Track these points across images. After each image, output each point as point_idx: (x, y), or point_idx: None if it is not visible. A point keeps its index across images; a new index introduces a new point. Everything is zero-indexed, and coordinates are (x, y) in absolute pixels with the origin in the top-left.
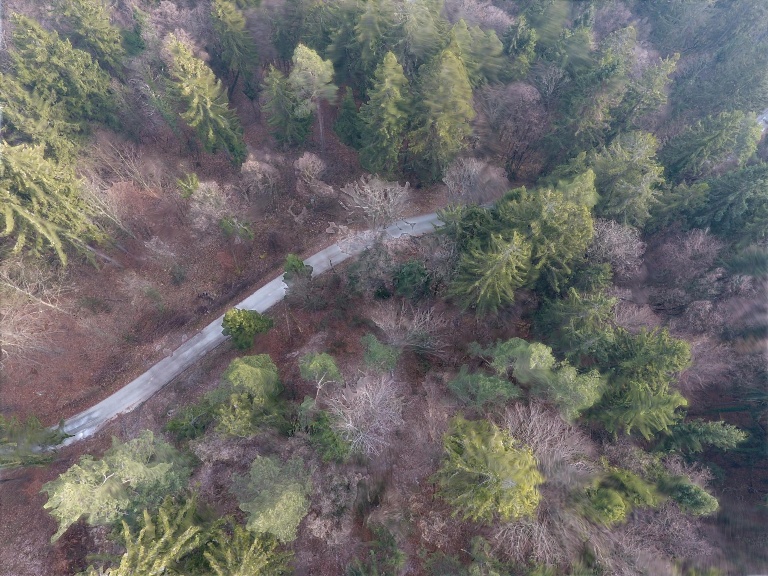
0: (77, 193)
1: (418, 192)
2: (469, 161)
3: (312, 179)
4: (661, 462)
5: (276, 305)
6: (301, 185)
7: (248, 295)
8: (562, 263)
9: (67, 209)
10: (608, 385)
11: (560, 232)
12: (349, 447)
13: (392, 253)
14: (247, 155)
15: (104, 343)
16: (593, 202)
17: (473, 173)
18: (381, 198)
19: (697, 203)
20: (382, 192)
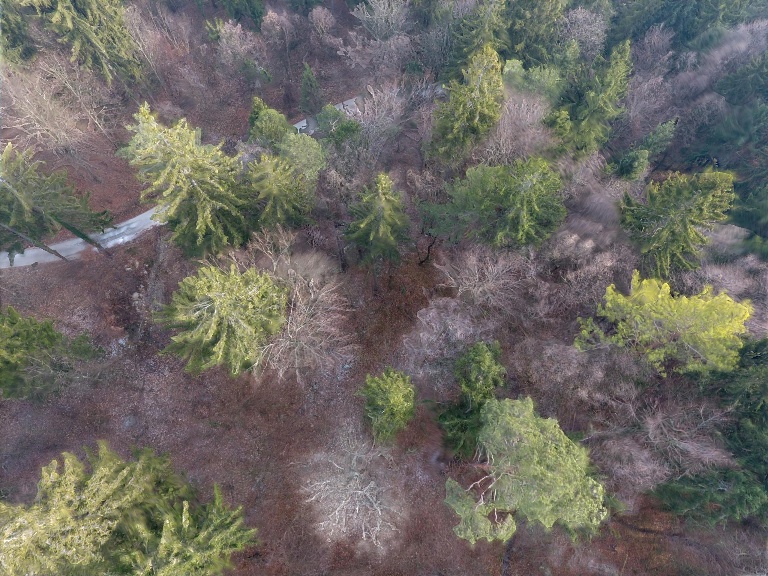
0: (122, 21)
1: None
2: (462, 1)
3: (324, 33)
4: (612, 169)
5: None
6: (314, 37)
7: None
8: (538, 46)
9: (113, 33)
10: (571, 117)
11: (534, 1)
12: None
13: (394, 47)
14: (266, 14)
15: None
16: (565, 1)
17: (466, 12)
18: (385, 9)
19: (655, 8)
20: (386, 2)
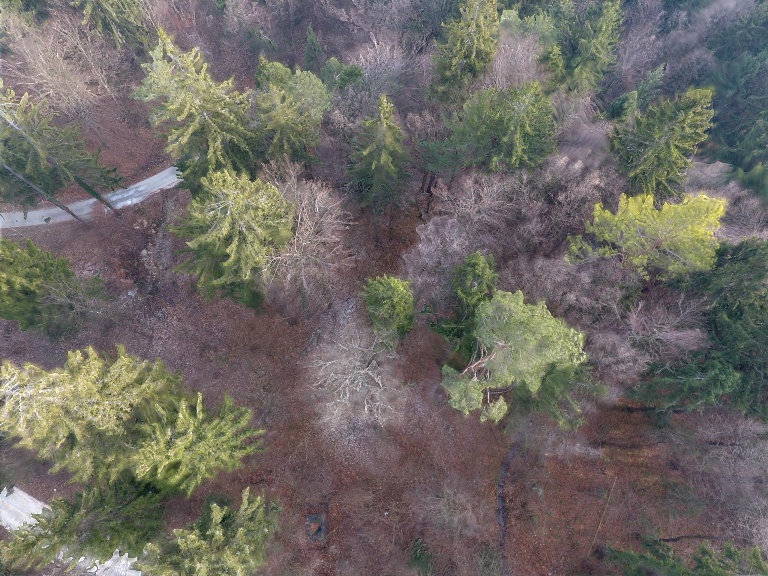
0: None
1: None
2: None
3: (327, 4)
4: None
5: None
6: (318, 7)
7: None
8: (534, 7)
9: None
10: (565, 69)
11: None
12: (362, 66)
13: (396, 9)
14: None
15: (146, 147)
16: None
17: None
18: None
19: None
20: None
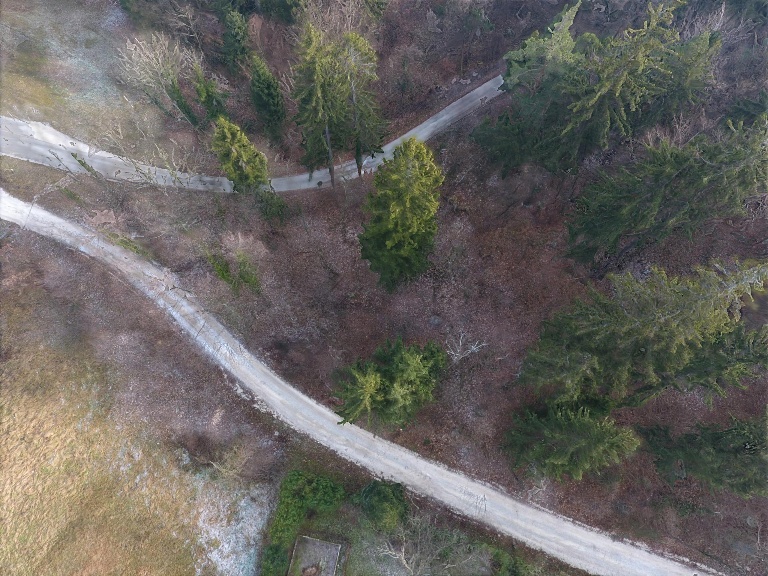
0: None
1: (597, 29)
2: None
3: None
4: None
5: (501, 95)
6: None
7: (477, 86)
8: None
9: None
10: None
11: None
12: None
13: None
14: None
15: None
16: None
17: None
18: None
19: None
20: None
